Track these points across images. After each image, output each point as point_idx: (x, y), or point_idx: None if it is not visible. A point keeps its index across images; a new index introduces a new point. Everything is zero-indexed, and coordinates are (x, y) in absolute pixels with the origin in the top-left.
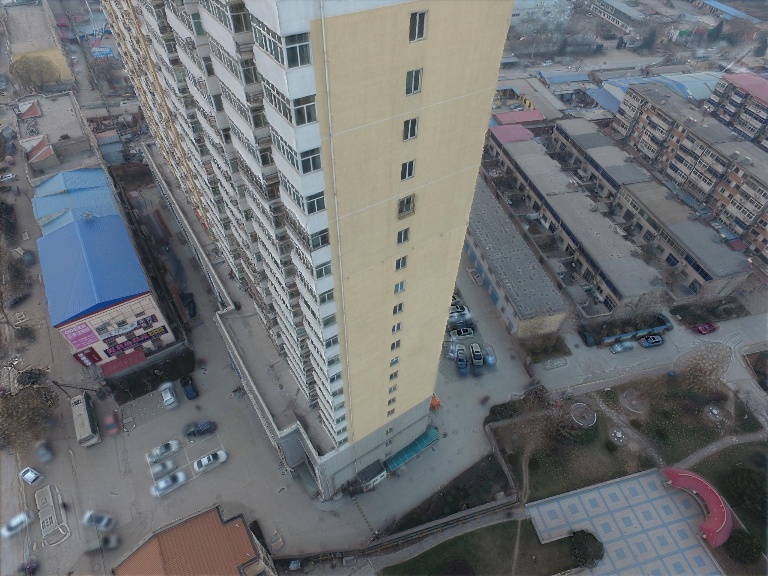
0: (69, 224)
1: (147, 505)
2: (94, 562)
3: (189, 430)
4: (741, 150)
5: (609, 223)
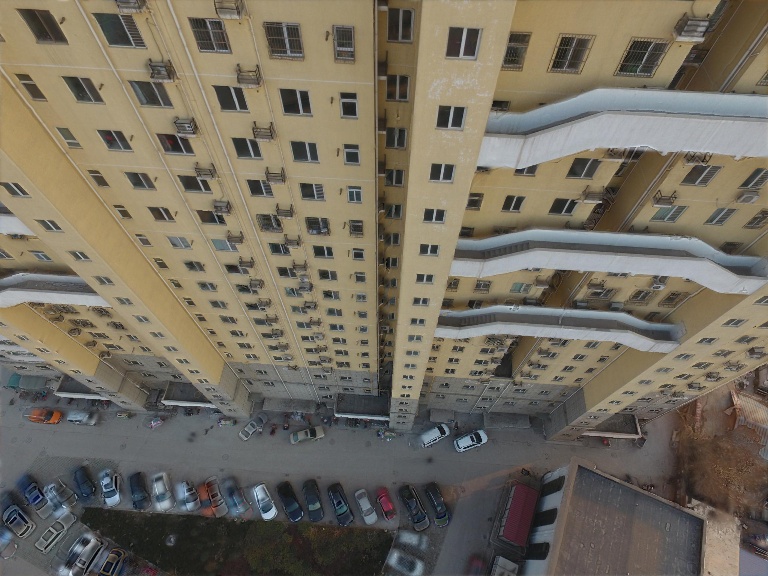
0: None
1: None
2: None
3: None
4: None
5: None
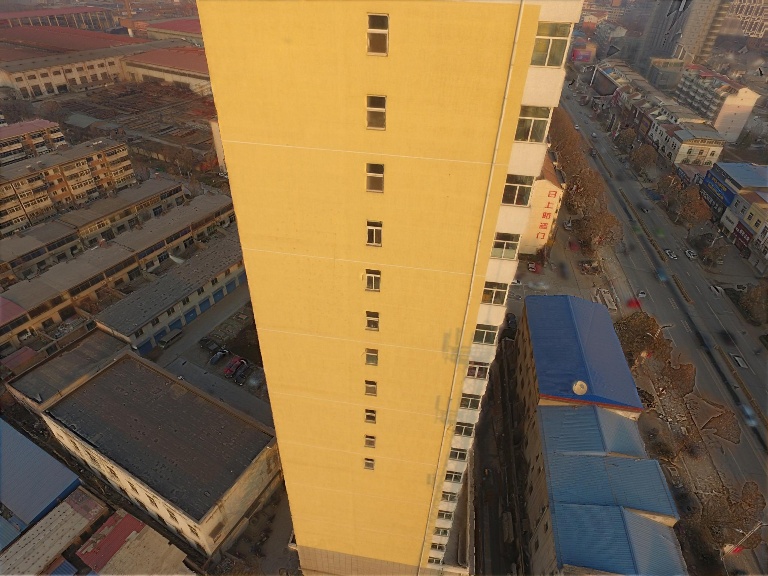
0: (603, 396)
1: (552, 287)
2: (582, 283)
3: (519, 303)
4: (14, 170)
5: (153, 220)
